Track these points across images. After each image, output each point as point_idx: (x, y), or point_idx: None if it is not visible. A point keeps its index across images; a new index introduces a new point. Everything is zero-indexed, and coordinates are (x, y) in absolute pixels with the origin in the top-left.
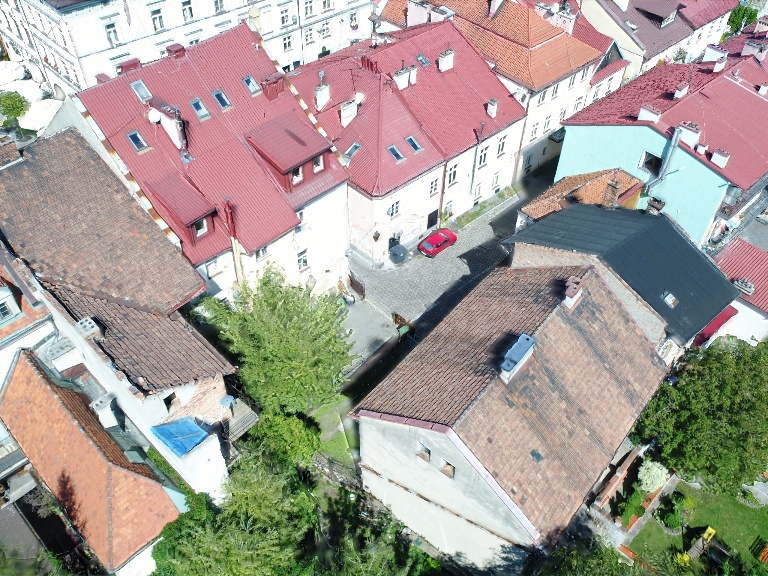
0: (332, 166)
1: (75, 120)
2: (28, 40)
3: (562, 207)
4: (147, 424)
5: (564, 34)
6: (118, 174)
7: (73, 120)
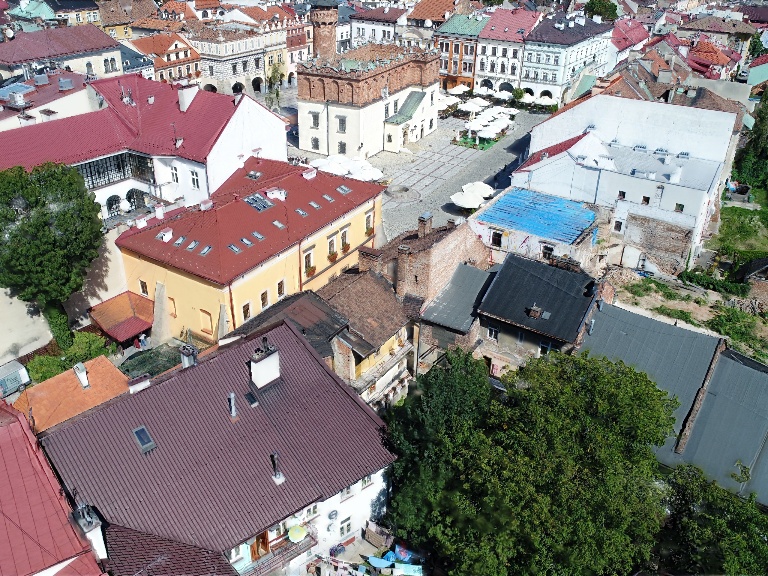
0: (709, 71)
1: None
2: (511, 72)
3: (763, 89)
4: (747, 98)
5: (720, 52)
6: (678, 63)
7: None
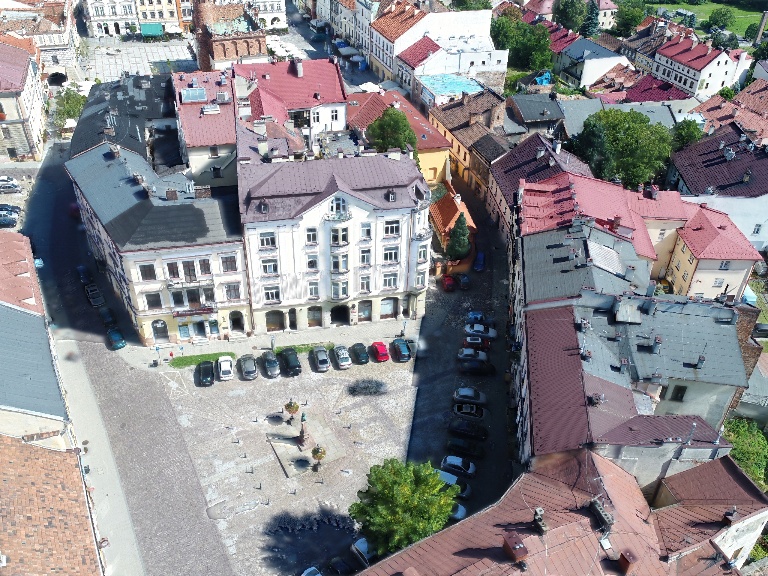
0: None
1: None
2: None
3: None
4: None
5: None
6: None
7: None
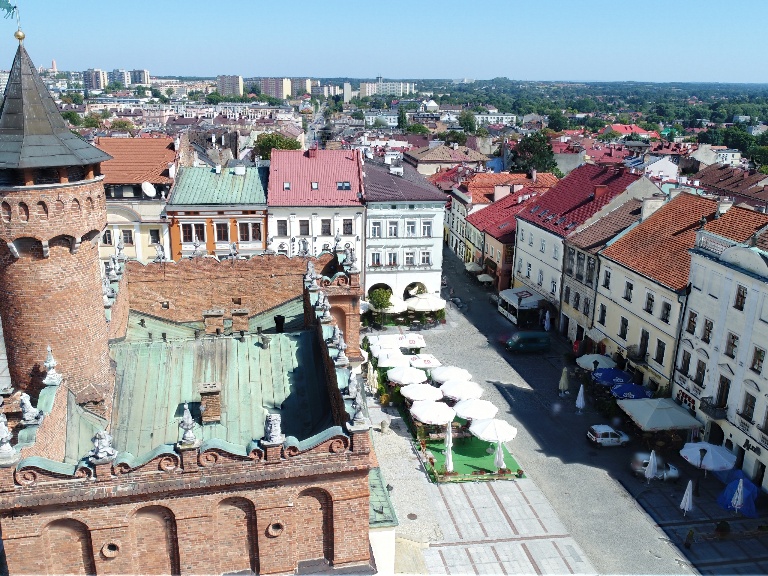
0: None
1: (639, 192)
2: None
3: None
4: None
5: None
6: None
7: (636, 193)
